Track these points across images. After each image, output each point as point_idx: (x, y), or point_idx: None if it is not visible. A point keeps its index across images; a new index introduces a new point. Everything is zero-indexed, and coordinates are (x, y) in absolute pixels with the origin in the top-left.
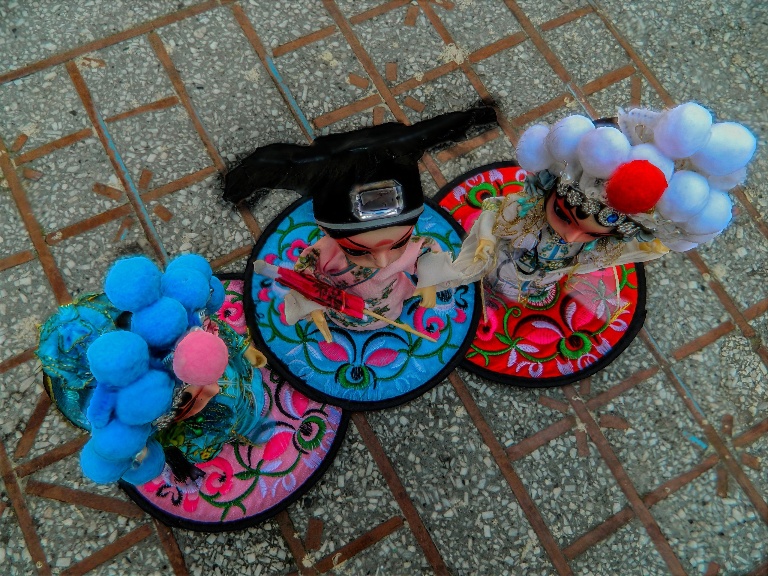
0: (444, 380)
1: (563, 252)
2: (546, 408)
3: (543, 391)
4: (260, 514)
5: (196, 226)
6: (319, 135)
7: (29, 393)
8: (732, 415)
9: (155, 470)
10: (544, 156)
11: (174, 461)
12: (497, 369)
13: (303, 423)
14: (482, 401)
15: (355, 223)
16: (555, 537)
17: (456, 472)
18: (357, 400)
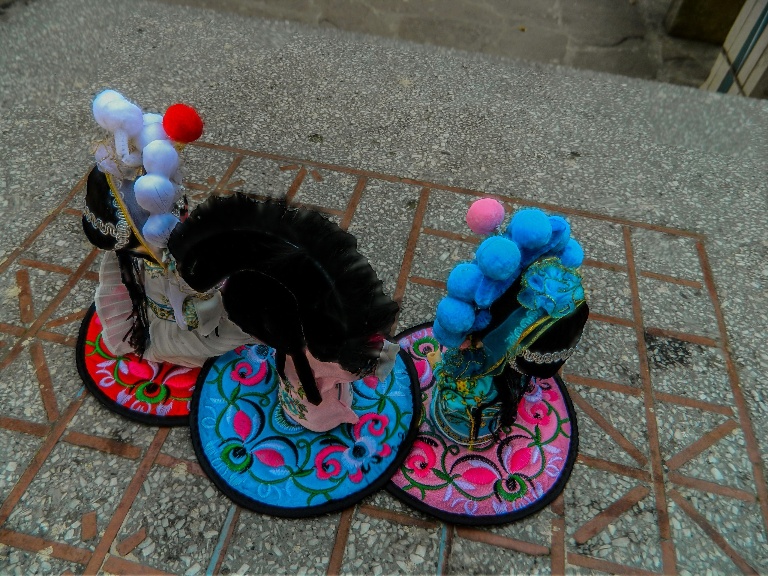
0: None
1: None
2: None
3: None
4: None
5: (393, 573)
6: (202, 573)
7: (622, 532)
8: (191, 197)
9: None
10: (171, 214)
11: None
12: None
13: None
14: None
15: None
16: (340, 222)
17: None
18: None
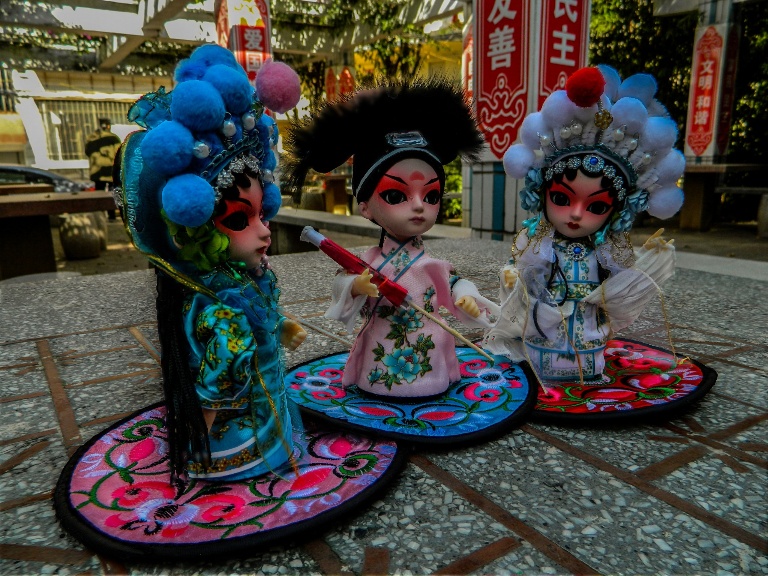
0: (519, 432)
1: (584, 270)
2: (661, 442)
3: (647, 432)
4: (286, 526)
5: None
6: (344, 337)
7: None
8: None
9: (206, 188)
10: (524, 150)
11: (181, 399)
12: (577, 411)
13: (346, 460)
14: (575, 442)
15: (392, 152)
16: None
17: (576, 494)
18: (414, 434)
